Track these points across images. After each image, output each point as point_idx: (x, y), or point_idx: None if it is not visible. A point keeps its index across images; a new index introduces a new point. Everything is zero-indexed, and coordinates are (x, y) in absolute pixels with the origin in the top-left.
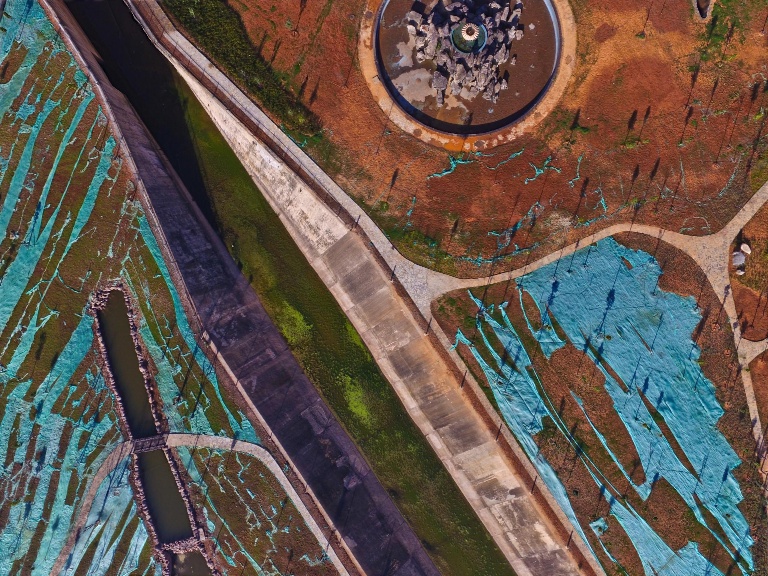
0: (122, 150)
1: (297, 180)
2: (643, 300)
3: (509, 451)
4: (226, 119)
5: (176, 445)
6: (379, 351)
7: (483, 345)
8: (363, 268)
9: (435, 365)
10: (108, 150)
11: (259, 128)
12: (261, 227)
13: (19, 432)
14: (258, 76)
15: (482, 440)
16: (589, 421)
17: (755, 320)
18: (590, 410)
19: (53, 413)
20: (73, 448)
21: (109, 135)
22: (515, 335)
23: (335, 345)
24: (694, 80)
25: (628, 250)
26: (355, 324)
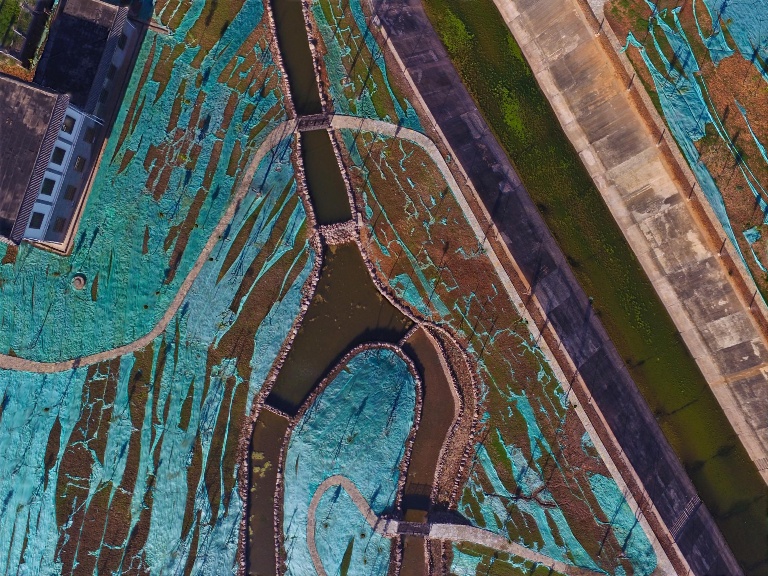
0: None
1: None
2: None
3: (670, 156)
4: None
5: (340, 127)
6: (540, 63)
7: (653, 49)
8: None
9: (603, 68)
10: None
11: None
12: None
13: (184, 98)
14: None
15: (643, 146)
16: (751, 131)
17: None
18: (753, 120)
19: (219, 82)
20: (237, 119)
21: None
22: (685, 41)
23: (495, 57)
24: None
25: None
26: (517, 36)
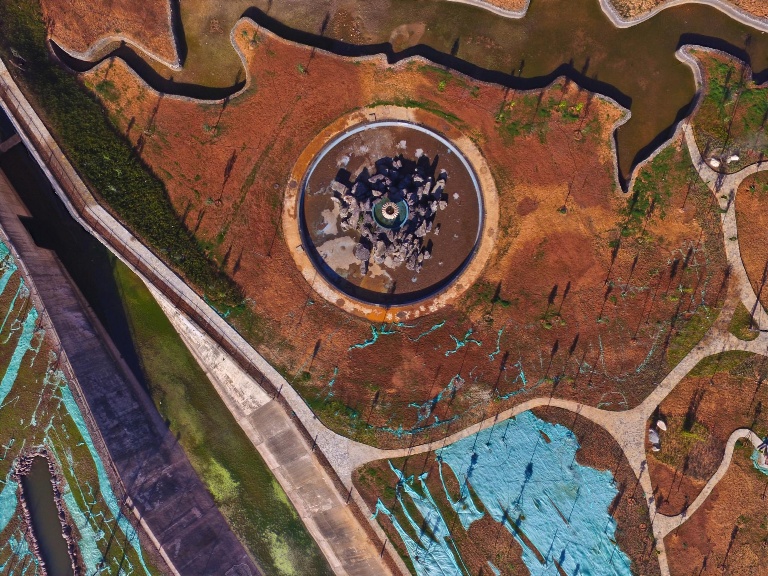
0: (44, 321)
1: (219, 350)
2: (560, 474)
3: None
4: (150, 287)
5: None
6: (304, 510)
7: (403, 515)
8: (286, 435)
9: (356, 532)
10: (30, 321)
11: (182, 299)
12: (189, 384)
13: None
14: (181, 247)
15: None
16: None
17: (670, 495)
18: None
19: None
20: None
21: (31, 307)
22: (434, 506)
23: (261, 502)
24: (614, 256)
25: (546, 424)
26: (281, 482)
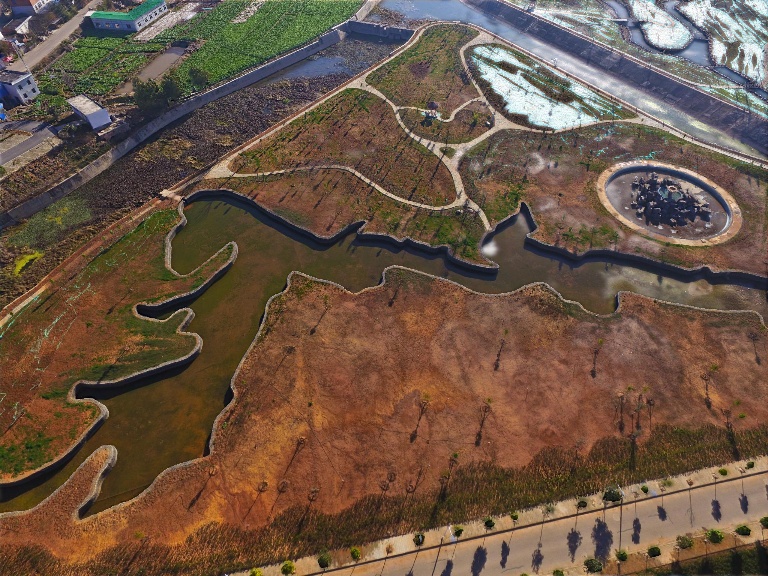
0: None
1: None
2: None
3: (582, 82)
4: None
5: None
6: None
7: None
8: None
9: None
10: None
11: None
12: None
13: None
14: None
15: None
16: None
17: (480, 106)
18: None
19: None
20: None
21: None
22: None
23: None
24: (525, 177)
25: None
26: None
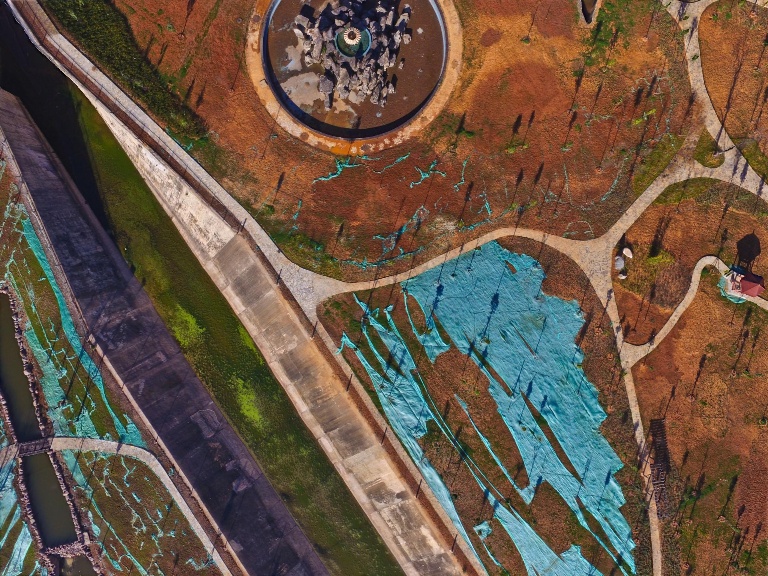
0: (5, 153)
1: (182, 183)
2: (527, 304)
3: (394, 455)
4: (113, 122)
5: (61, 449)
6: (271, 354)
7: (368, 349)
8: (251, 271)
9: (321, 369)
10: None
11: (144, 131)
12: (154, 230)
13: None
14: (143, 79)
15: (368, 444)
16: (473, 425)
17: (637, 324)
18: (474, 414)
19: None
20: None
21: None
22: (400, 339)
23: (228, 348)
24: (578, 85)
25: (512, 254)
26: (247, 327)
